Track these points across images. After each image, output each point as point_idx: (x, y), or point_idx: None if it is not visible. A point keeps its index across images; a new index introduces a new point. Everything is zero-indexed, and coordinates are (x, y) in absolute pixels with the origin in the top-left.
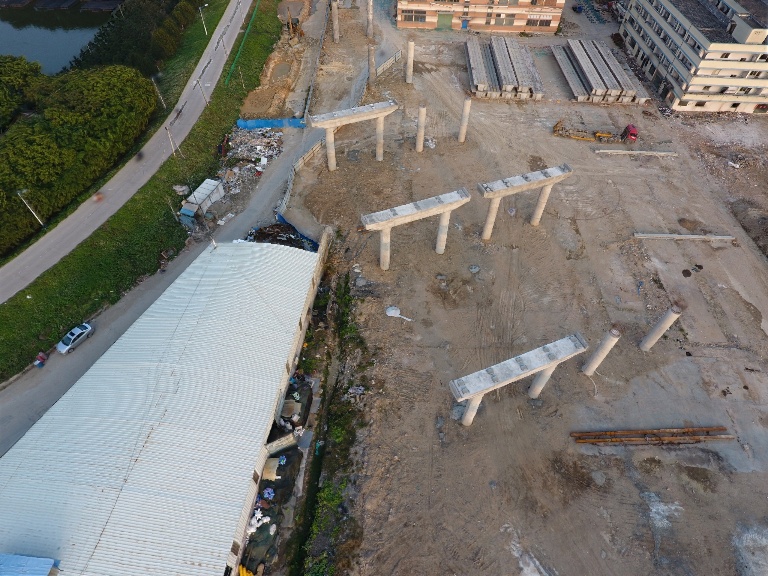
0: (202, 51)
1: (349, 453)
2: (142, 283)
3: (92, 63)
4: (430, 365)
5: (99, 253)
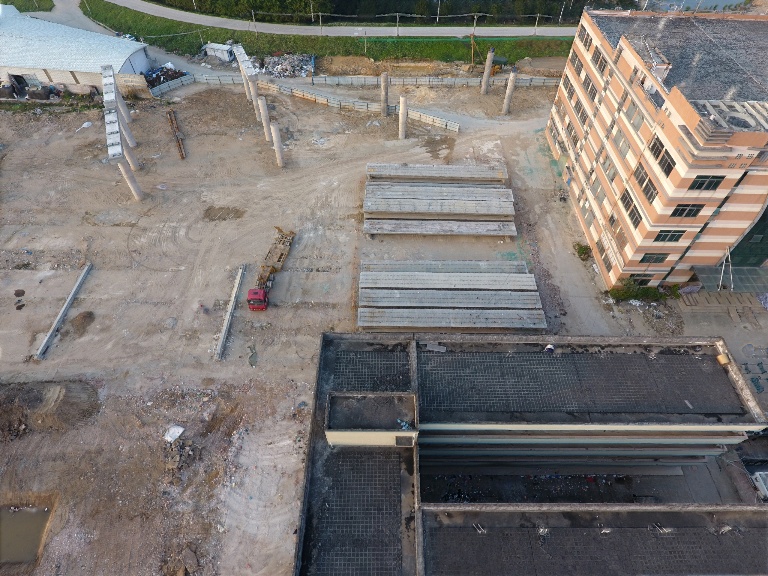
0: (413, 26)
1: (2, 109)
2: (161, 49)
3: (400, 0)
4: (36, 137)
5: (175, 28)
